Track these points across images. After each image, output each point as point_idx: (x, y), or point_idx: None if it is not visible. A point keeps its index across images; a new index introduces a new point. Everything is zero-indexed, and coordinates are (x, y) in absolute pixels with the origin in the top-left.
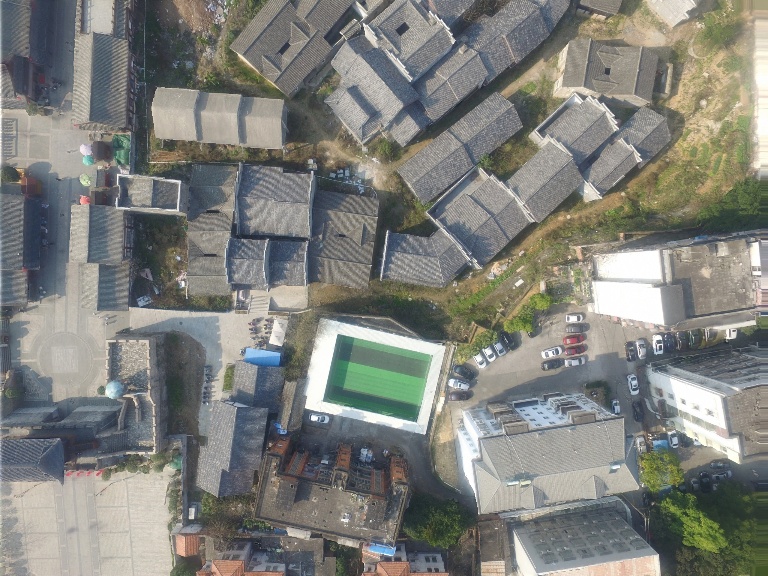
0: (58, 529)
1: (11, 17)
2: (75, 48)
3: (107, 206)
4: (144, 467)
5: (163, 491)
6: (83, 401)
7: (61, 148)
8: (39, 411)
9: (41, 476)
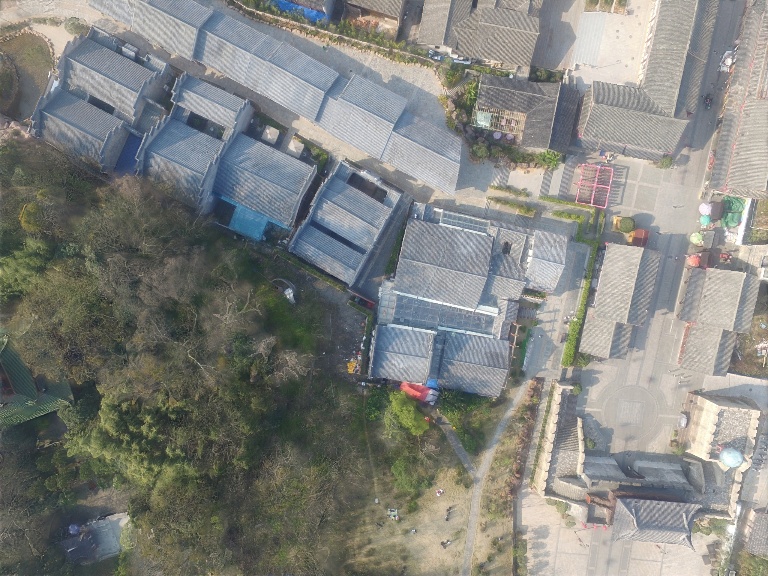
0: (587, 575)
1: (690, 71)
2: (745, 111)
3: (752, 275)
4: (710, 529)
5: (700, 550)
6: (640, 455)
7: (668, 202)
8: (603, 462)
9: (674, 539)
